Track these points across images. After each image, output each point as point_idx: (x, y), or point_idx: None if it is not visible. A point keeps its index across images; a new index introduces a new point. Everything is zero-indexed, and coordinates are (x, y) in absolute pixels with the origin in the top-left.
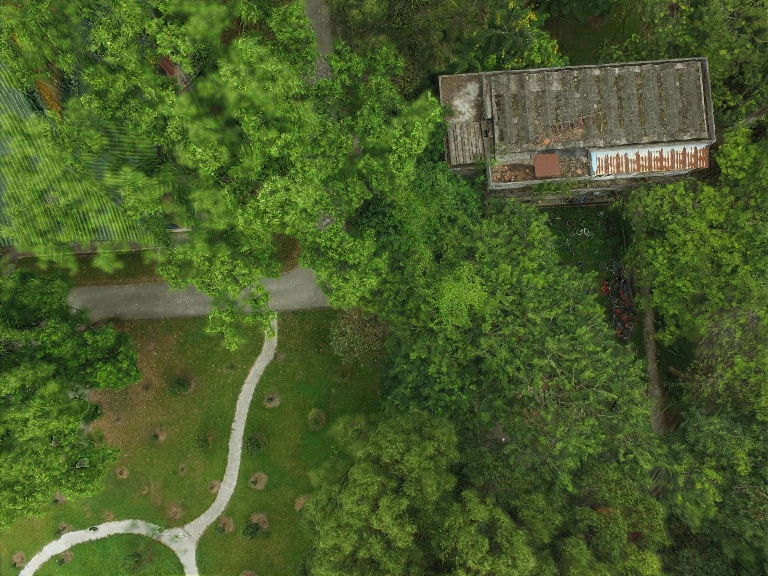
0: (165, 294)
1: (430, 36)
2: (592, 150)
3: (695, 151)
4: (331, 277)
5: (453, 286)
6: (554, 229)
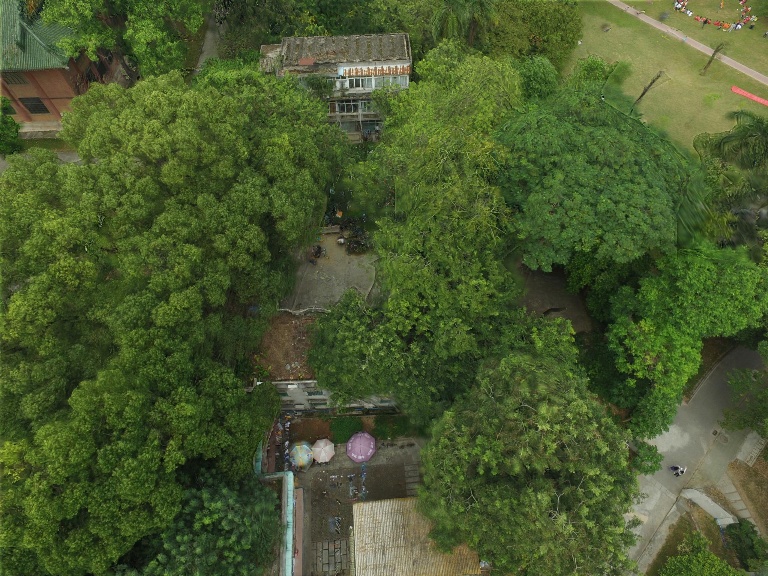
0: (65, 158)
1: (246, 12)
2: (339, 63)
3: (403, 67)
4: (136, 35)
5: (219, 71)
6: (351, 151)
